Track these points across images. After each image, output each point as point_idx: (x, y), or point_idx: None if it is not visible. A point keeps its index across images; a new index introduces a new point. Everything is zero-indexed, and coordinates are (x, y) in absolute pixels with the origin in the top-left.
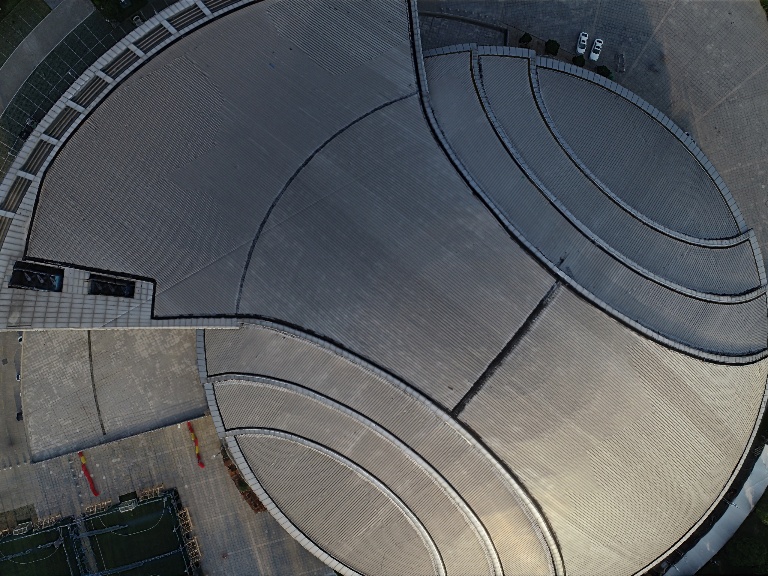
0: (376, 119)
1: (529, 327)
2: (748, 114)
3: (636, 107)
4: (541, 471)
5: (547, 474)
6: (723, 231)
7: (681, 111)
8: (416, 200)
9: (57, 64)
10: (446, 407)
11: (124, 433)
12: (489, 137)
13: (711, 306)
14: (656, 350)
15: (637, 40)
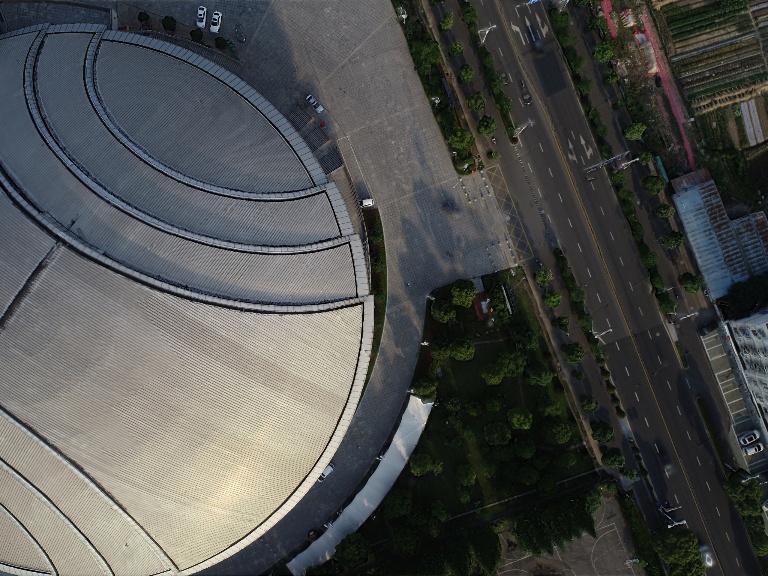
0: None
1: (29, 289)
2: (371, 73)
3: (201, 71)
4: (68, 431)
5: (76, 433)
6: (289, 185)
7: (306, 75)
8: None
9: None
10: None
11: None
12: (19, 110)
13: (257, 257)
14: (175, 303)
15: (256, 10)
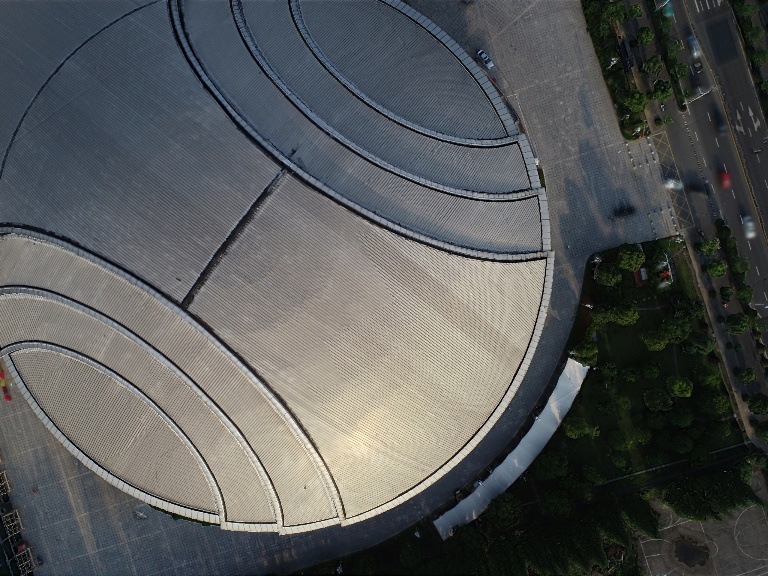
0: (125, 24)
1: (253, 215)
2: (543, 31)
3: (400, 13)
4: (278, 363)
5: (285, 366)
6: (486, 132)
7: (477, 30)
8: (149, 96)
9: None
10: (176, 299)
11: None
12: (232, 37)
13: (462, 201)
14: (392, 239)
15: None
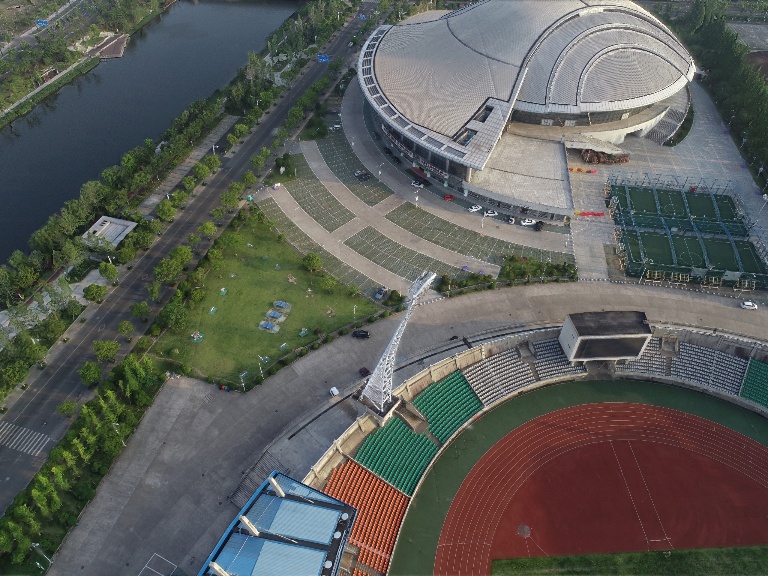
0: None
1: None
2: None
3: None
4: (618, 2)
5: (620, 2)
6: None
7: None
8: (496, 7)
9: None
10: None
11: None
12: None
13: None
14: None
15: None
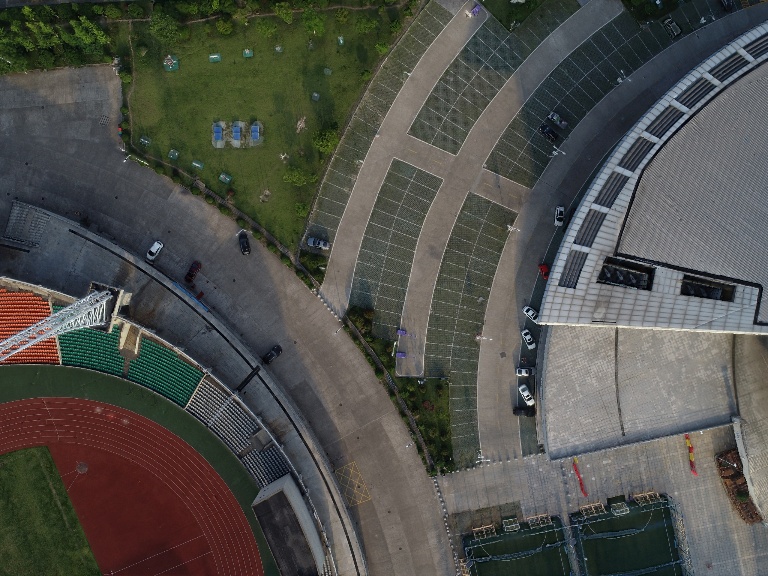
0: None
1: None
2: None
3: None
4: None
5: None
6: None
7: None
8: None
9: (581, 61)
10: None
11: (644, 436)
12: None
13: None
14: None
15: None
